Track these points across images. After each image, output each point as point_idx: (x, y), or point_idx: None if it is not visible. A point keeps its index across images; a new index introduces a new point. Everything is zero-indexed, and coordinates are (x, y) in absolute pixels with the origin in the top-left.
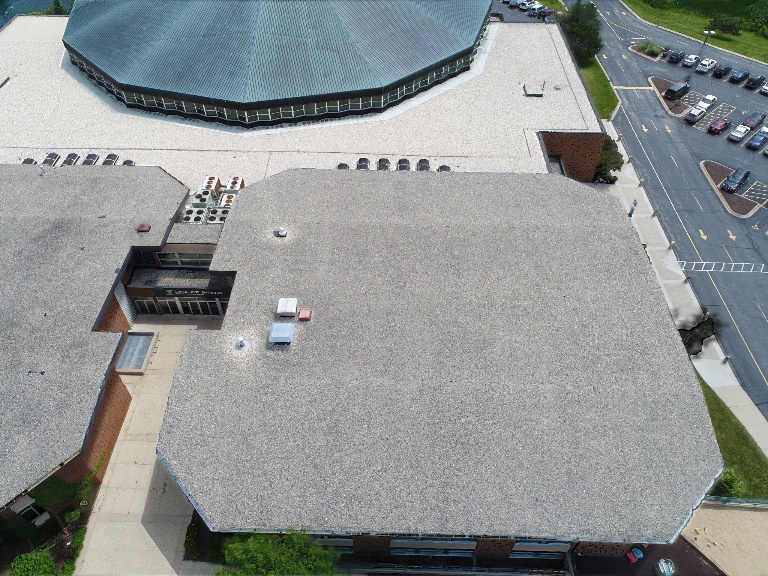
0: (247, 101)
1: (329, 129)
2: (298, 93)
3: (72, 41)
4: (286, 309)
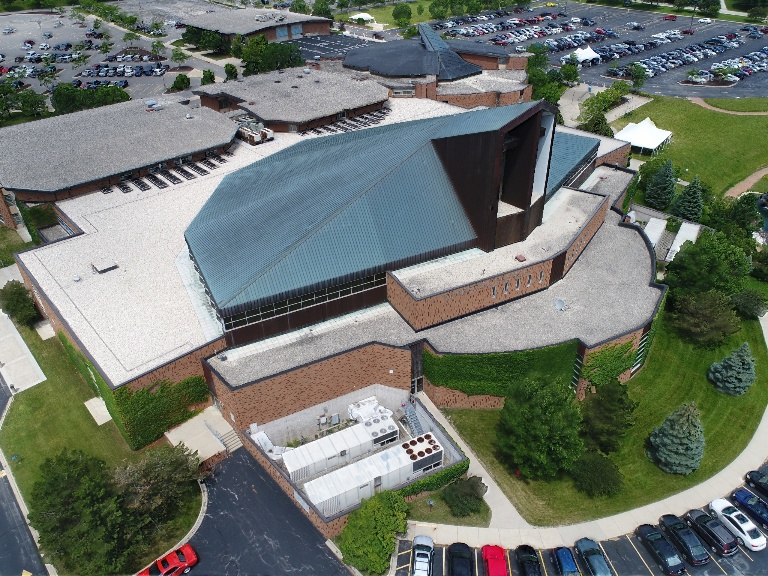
0: None
1: None
2: None
3: None
4: (156, 105)
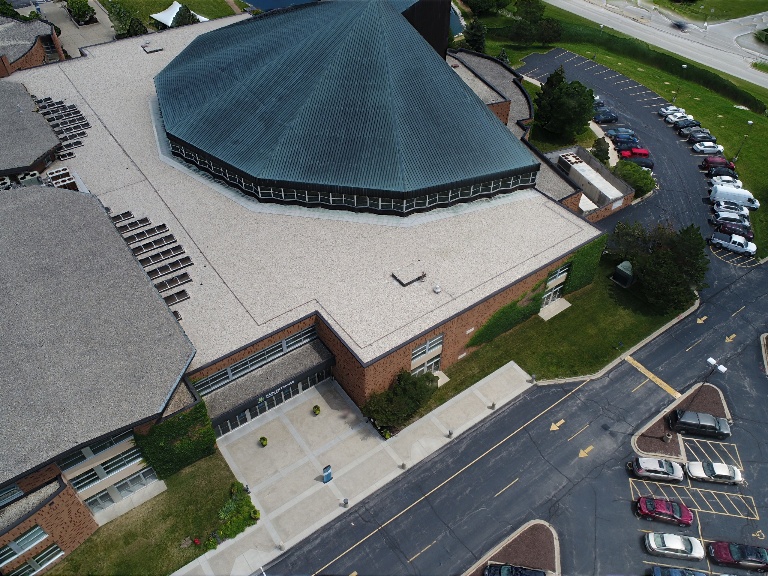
0: (169, 131)
1: (205, 189)
2: (202, 145)
3: (196, 39)
4: None
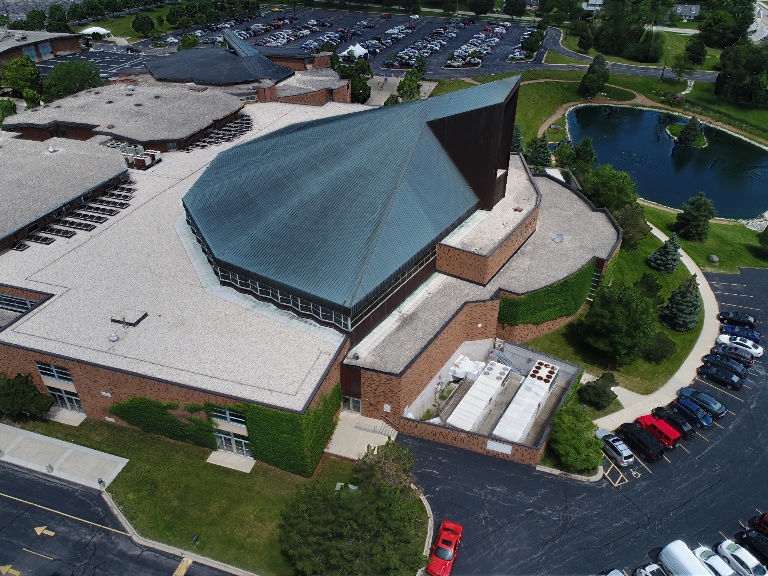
0: (219, 153)
1: None
2: None
3: None
4: None
